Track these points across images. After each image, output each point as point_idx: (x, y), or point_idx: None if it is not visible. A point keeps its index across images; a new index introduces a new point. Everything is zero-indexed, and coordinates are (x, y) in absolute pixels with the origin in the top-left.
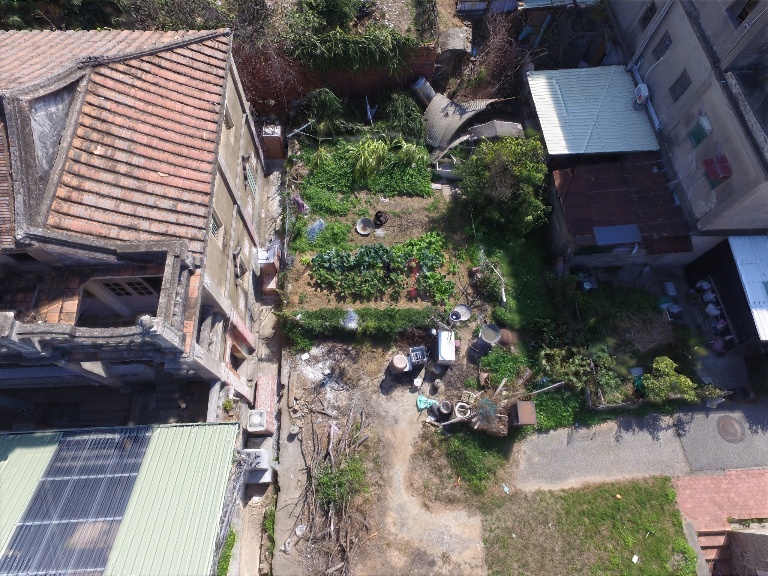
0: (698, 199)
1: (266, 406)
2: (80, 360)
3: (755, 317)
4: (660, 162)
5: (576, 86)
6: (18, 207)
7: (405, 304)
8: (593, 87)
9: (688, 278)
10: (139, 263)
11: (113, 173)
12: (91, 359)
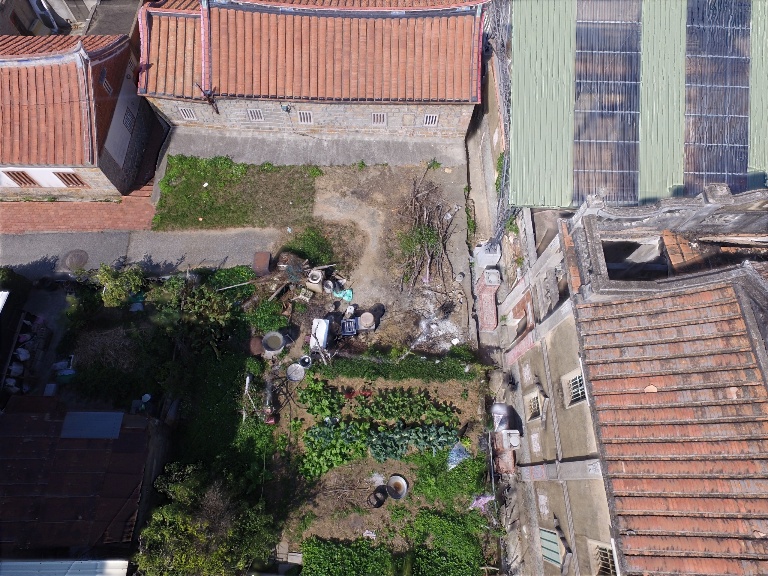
0: None
1: (486, 300)
2: None
3: None
4: None
5: None
6: (766, 283)
7: (356, 384)
8: None
9: None
10: None
11: (703, 372)
12: None
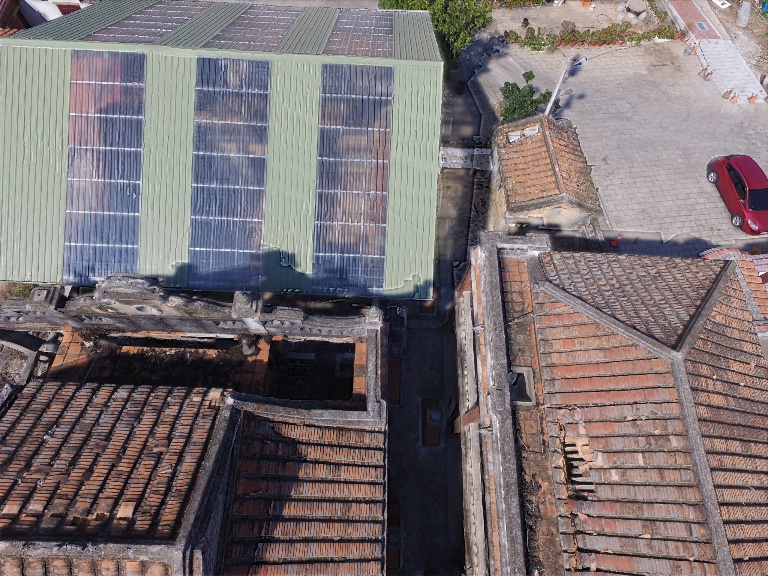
0: None
1: None
2: None
3: None
4: None
5: None
6: None
7: None
8: None
9: None
10: None
11: None
12: None
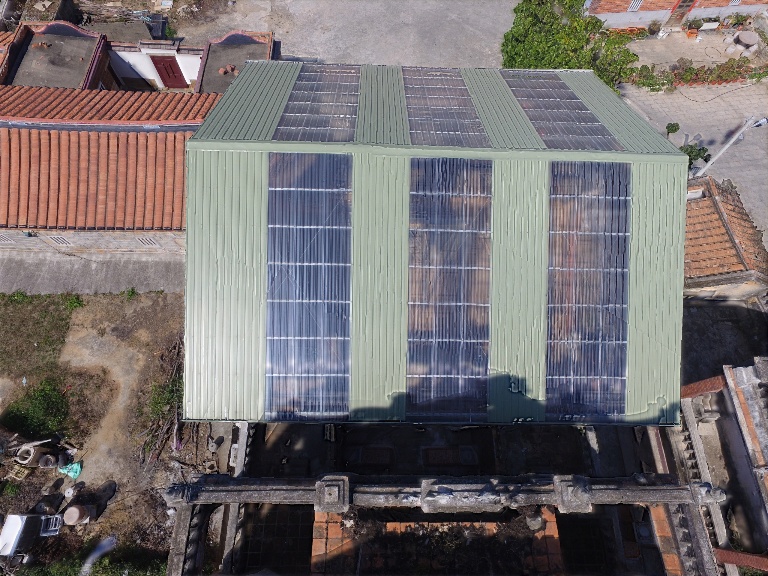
0: None
1: None
2: (306, 480)
3: None
4: None
5: None
6: None
7: None
8: None
9: None
10: None
11: None
12: (294, 480)
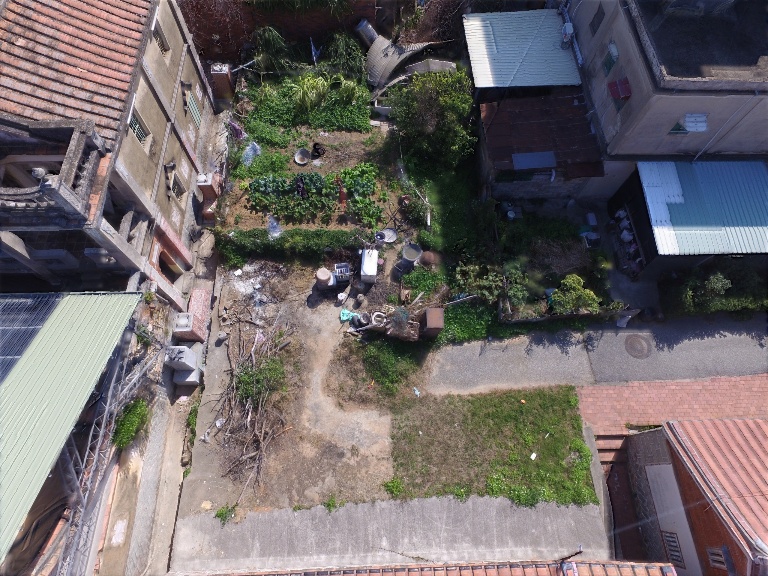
0: (608, 125)
1: (198, 315)
2: None
3: (655, 234)
4: (581, 96)
5: (508, 27)
6: None
7: (335, 226)
8: (525, 28)
9: (610, 211)
10: (51, 141)
11: (32, 63)
12: (3, 224)
